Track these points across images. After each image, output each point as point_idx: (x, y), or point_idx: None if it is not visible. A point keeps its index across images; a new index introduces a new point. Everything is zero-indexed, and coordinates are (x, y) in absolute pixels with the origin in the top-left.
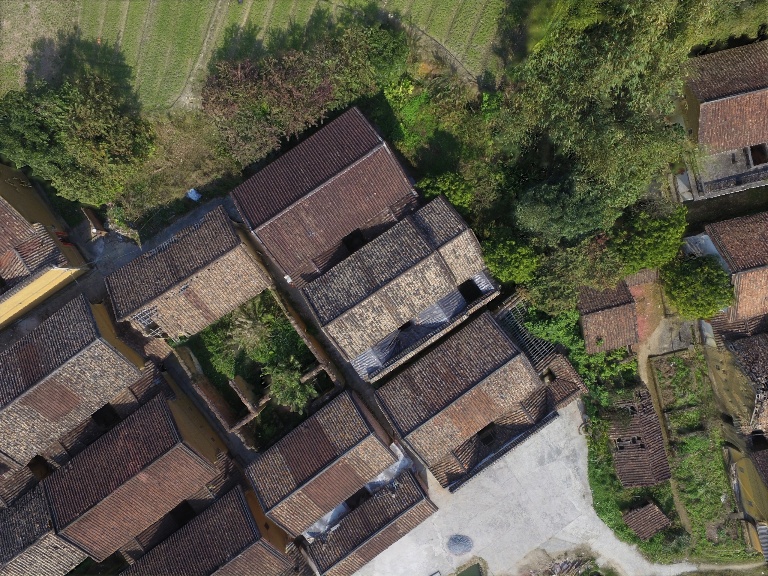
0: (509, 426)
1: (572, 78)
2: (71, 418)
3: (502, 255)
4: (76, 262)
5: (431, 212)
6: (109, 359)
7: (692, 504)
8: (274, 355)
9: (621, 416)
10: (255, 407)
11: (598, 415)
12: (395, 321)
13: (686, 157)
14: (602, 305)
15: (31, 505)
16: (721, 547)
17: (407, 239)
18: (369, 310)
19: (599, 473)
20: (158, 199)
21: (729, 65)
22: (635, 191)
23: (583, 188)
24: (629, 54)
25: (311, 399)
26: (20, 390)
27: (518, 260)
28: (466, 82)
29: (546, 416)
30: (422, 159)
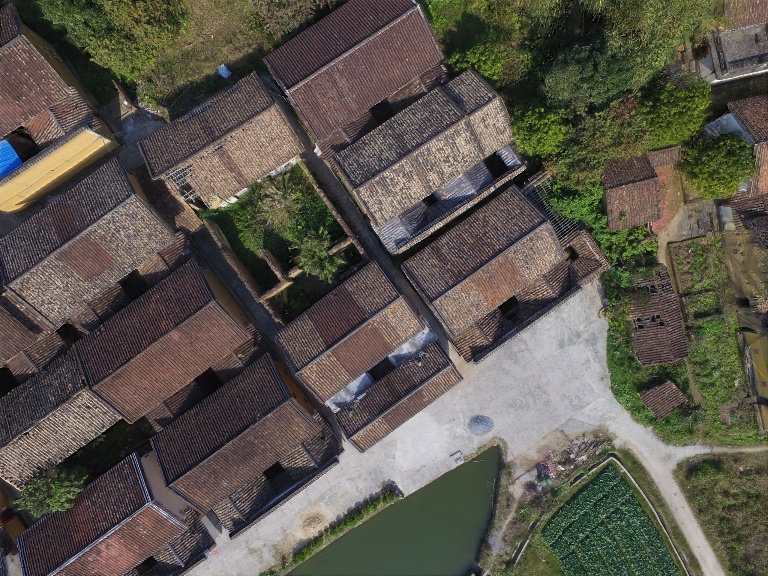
0: (532, 302)
1: None
2: (104, 279)
3: (531, 123)
4: (107, 134)
5: (461, 84)
6: (143, 218)
7: (707, 388)
8: (302, 230)
9: (641, 295)
10: (285, 276)
11: (618, 297)
12: (424, 189)
13: (710, 37)
14: (626, 180)
15: (63, 368)
16: (734, 430)
17: (438, 107)
18: (400, 175)
19: (617, 356)
20: (189, 75)
21: None
22: (665, 49)
23: (615, 42)
24: None
25: (339, 272)
26: (55, 246)
27: (547, 126)
28: None
29: (569, 290)
30: (450, 42)
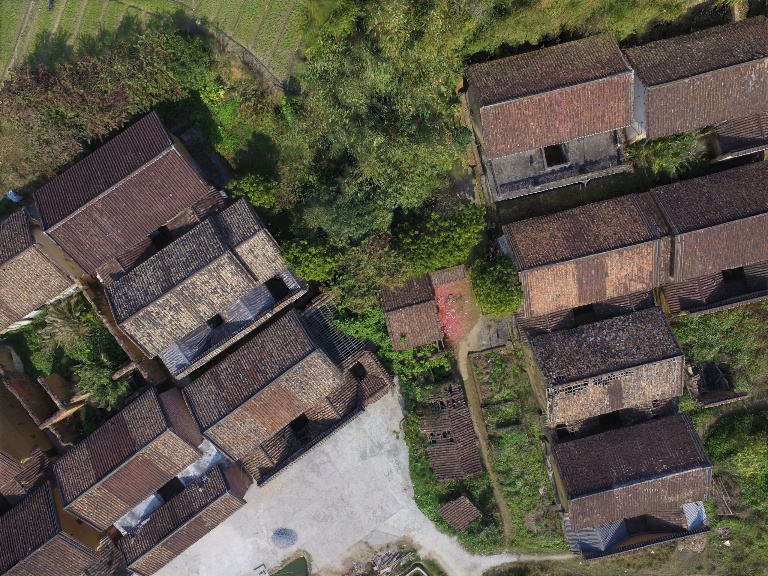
0: (320, 421)
1: (341, 83)
2: None
3: (296, 254)
4: None
5: (233, 213)
6: None
7: (511, 496)
8: (91, 353)
9: (431, 411)
10: (64, 404)
11: (415, 410)
12: (196, 319)
13: (486, 159)
14: (404, 303)
15: None
16: (540, 538)
17: (205, 239)
18: (166, 308)
19: (420, 467)
20: None
21: (513, 70)
22: (404, 192)
23: (349, 189)
24: (384, 60)
25: (124, 396)
26: None
27: (308, 259)
28: (272, 87)
29: (353, 411)
30: (241, 161)
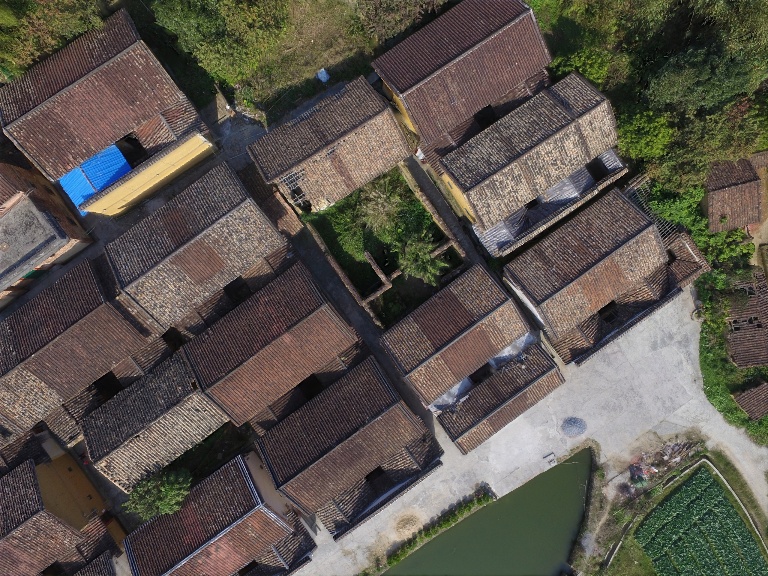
0: (632, 304)
1: None
2: (214, 282)
3: (639, 126)
4: (209, 138)
5: (565, 87)
6: (255, 222)
7: None
8: (402, 233)
9: (739, 297)
10: (389, 279)
11: (712, 299)
12: (531, 192)
13: None
14: (728, 183)
15: (170, 371)
16: None
17: (545, 110)
18: (509, 178)
19: (710, 358)
20: (288, 79)
21: None
22: None
23: (735, 46)
24: None
25: (440, 275)
26: (170, 250)
27: (656, 129)
28: None
29: (670, 292)
30: None
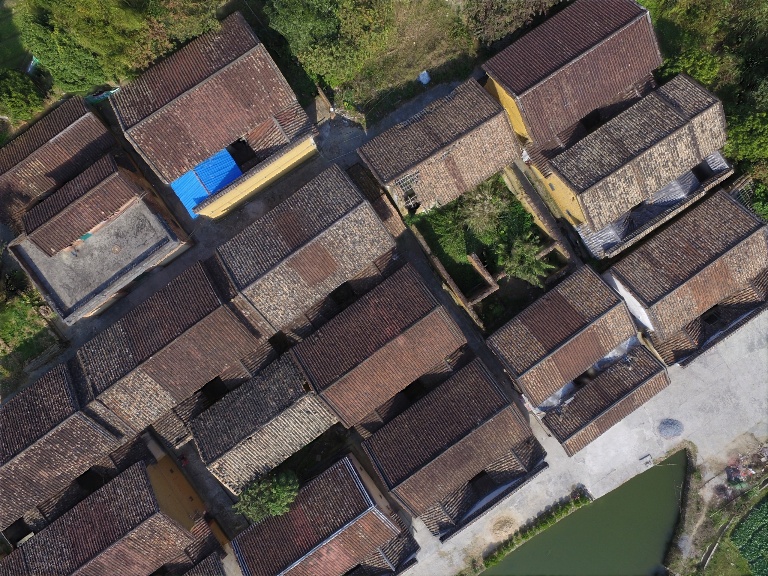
0: (735, 305)
1: None
2: (326, 284)
3: (752, 127)
4: None
5: (674, 89)
6: (370, 224)
7: None
8: (504, 235)
9: None
10: (495, 281)
11: None
12: (641, 194)
13: None
14: None
15: (280, 373)
16: None
17: (656, 112)
18: (621, 180)
19: None
20: (390, 81)
21: None
22: None
23: None
24: None
25: None
26: (286, 252)
27: None
28: None
29: None
30: None
